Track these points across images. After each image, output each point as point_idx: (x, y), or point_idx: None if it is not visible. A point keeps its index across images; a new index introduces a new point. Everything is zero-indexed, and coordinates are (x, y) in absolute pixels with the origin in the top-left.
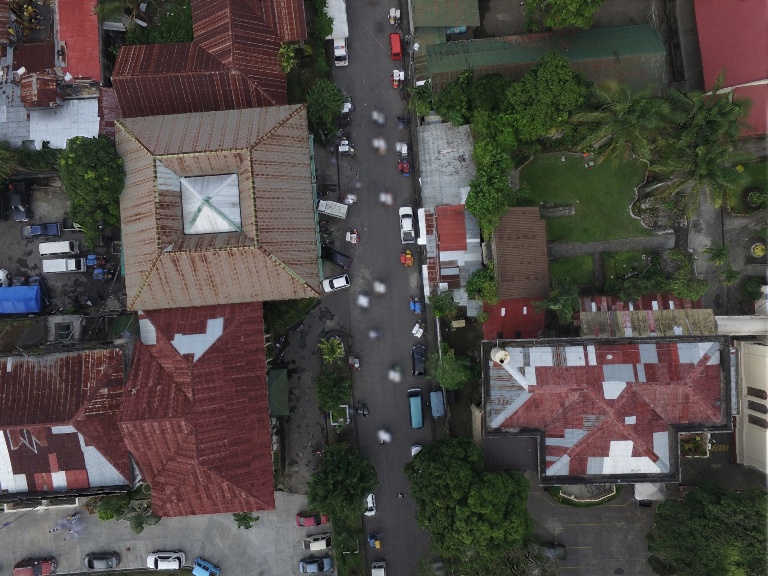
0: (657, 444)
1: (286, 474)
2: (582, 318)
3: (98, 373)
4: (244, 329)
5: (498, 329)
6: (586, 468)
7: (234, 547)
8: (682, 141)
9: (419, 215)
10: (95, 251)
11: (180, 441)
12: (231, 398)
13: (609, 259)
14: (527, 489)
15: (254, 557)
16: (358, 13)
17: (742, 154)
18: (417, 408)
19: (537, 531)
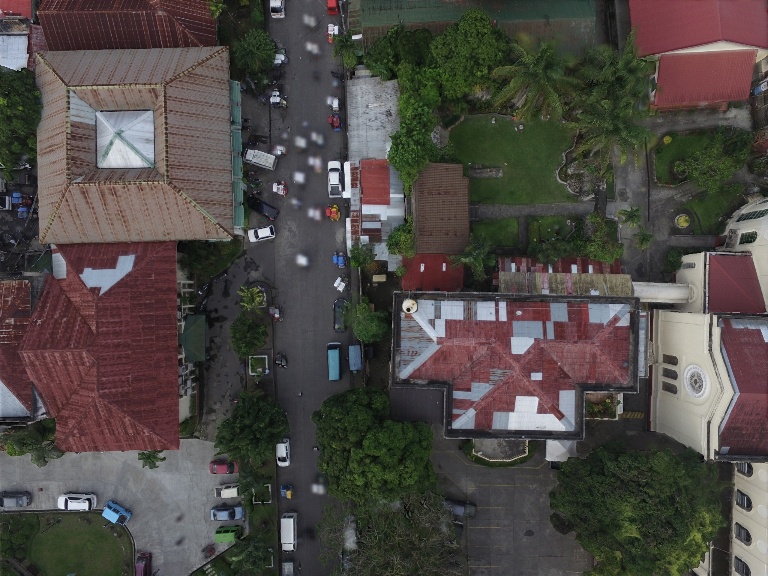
0: (563, 402)
1: (203, 422)
2: (501, 277)
3: (5, 303)
4: (155, 267)
5: (417, 285)
6: (491, 423)
7: (147, 492)
8: (593, 97)
9: (345, 168)
10: (22, 191)
11: (83, 374)
12: (137, 334)
13: (533, 222)
14: (430, 439)
15: (166, 503)
16: None
17: (672, 126)
18: (334, 361)
19: (450, 490)
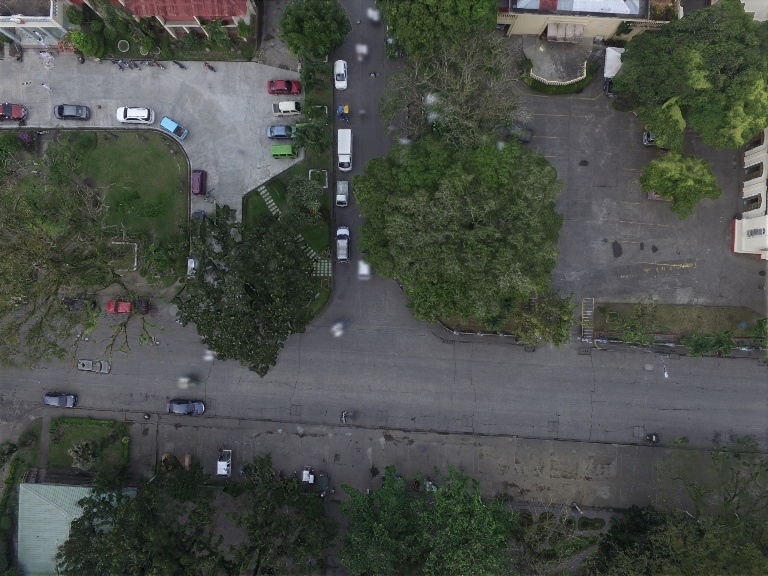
0: None
1: (261, 48)
2: None
3: None
4: None
5: None
6: (557, 2)
7: (204, 113)
8: None
9: None
10: None
11: None
12: None
13: None
14: (496, 4)
15: (223, 124)
16: None
17: None
18: None
19: None
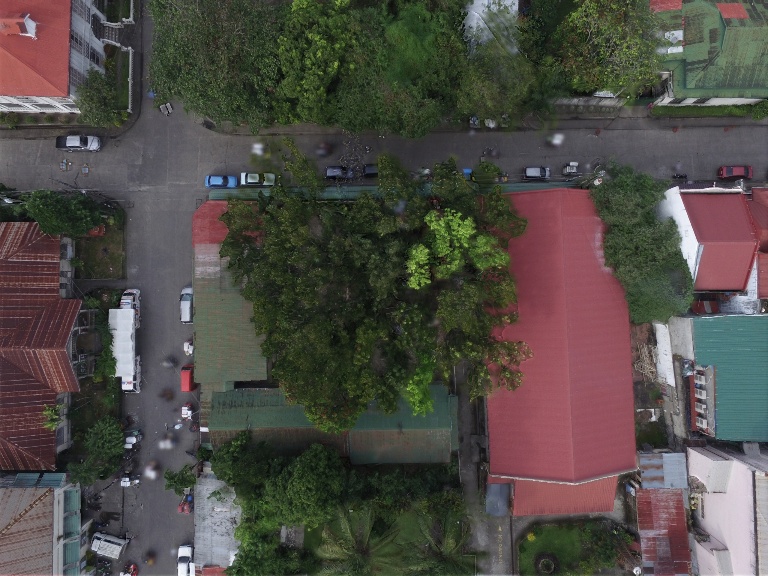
0: None
1: None
2: None
3: None
4: None
5: None
6: None
7: None
8: None
9: (190, 568)
10: None
11: None
12: None
13: None
14: None
15: None
16: (156, 336)
17: (539, 515)
18: None
19: None
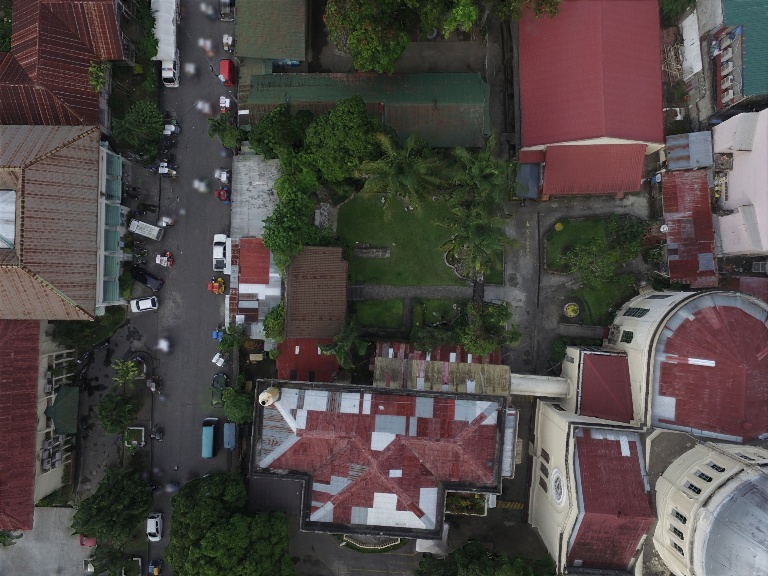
0: (424, 500)
1: (78, 491)
2: (377, 363)
3: None
4: (16, 346)
5: (292, 367)
6: (350, 517)
7: (18, 560)
8: (452, 199)
9: (227, 244)
10: None
11: None
12: None
13: (416, 306)
14: (282, 534)
15: (37, 572)
16: (195, 36)
17: (566, 211)
18: (208, 438)
19: (322, 572)
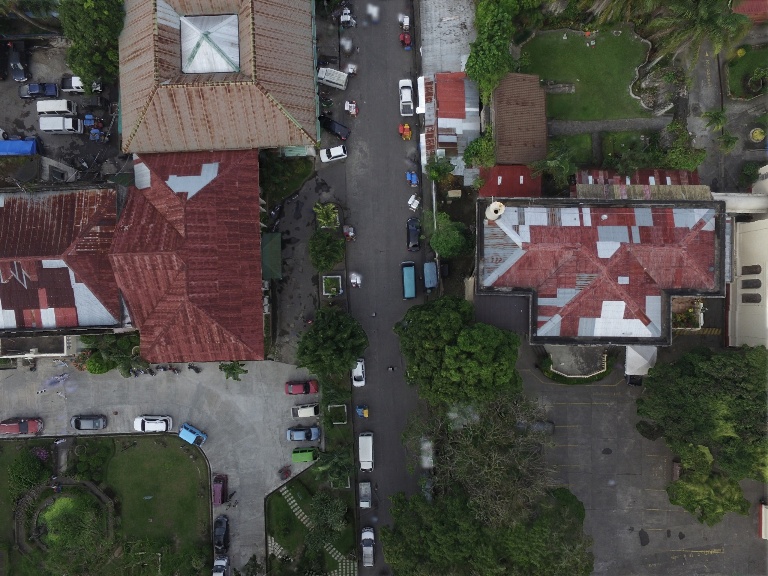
0: (649, 307)
1: (277, 344)
2: (578, 190)
3: (91, 211)
4: (239, 175)
5: None
6: (577, 329)
7: (222, 415)
8: None
9: (419, 84)
10: (93, 114)
11: (171, 279)
12: (223, 241)
13: (607, 136)
14: (517, 344)
15: (242, 425)
16: None
17: (744, 40)
18: (410, 278)
19: None
